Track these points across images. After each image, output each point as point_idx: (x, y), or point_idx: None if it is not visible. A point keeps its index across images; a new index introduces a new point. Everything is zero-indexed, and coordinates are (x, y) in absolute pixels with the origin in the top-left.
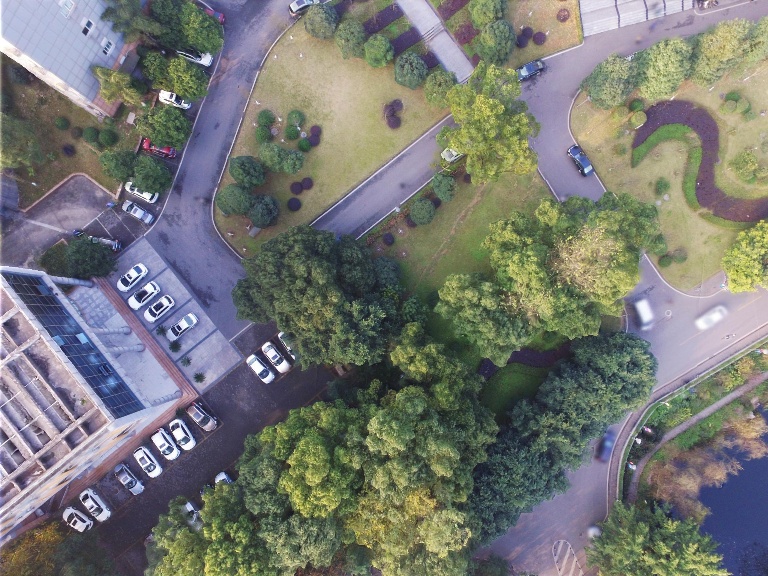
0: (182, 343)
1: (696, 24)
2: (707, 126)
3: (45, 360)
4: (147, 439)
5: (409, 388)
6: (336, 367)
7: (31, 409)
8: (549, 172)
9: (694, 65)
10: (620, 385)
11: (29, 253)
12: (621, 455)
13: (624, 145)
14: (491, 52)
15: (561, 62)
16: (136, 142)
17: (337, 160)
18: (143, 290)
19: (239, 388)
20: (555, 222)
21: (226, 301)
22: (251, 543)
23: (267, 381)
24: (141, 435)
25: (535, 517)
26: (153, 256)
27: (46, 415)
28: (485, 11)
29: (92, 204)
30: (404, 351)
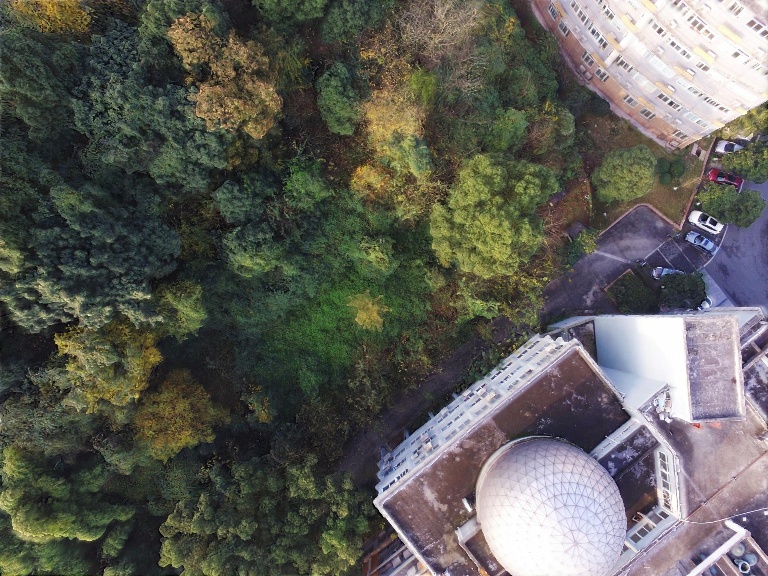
0: None
1: None
2: None
3: None
4: None
5: None
6: None
7: None
8: None
9: None
10: None
11: (594, 282)
12: None
13: None
14: None
15: None
16: (699, 173)
17: None
18: None
19: None
20: None
21: None
22: None
23: None
24: None
25: None
26: (712, 287)
27: None
28: None
29: (653, 234)
30: None
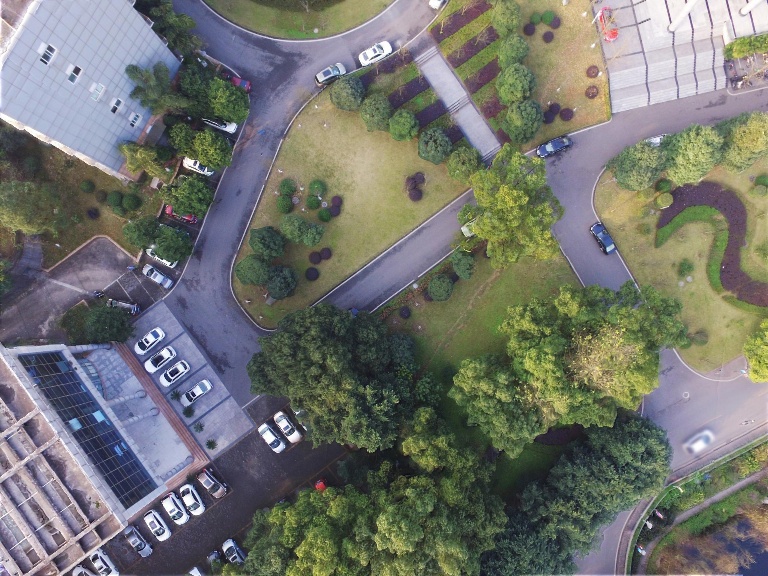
0: (196, 408)
1: (728, 104)
2: (735, 209)
3: (63, 461)
4: (157, 503)
5: (420, 479)
6: None
7: (47, 509)
8: (570, 249)
9: (725, 153)
10: (633, 476)
11: (50, 312)
12: (631, 537)
13: (648, 225)
14: (517, 131)
15: (587, 138)
16: (159, 206)
17: (357, 231)
18: (160, 355)
19: (250, 455)
20: (575, 315)
21: (241, 368)
22: None
23: (278, 451)
24: None
25: None
26: (171, 320)
27: (62, 517)
28: (512, 90)
29: (113, 266)
30: (416, 445)
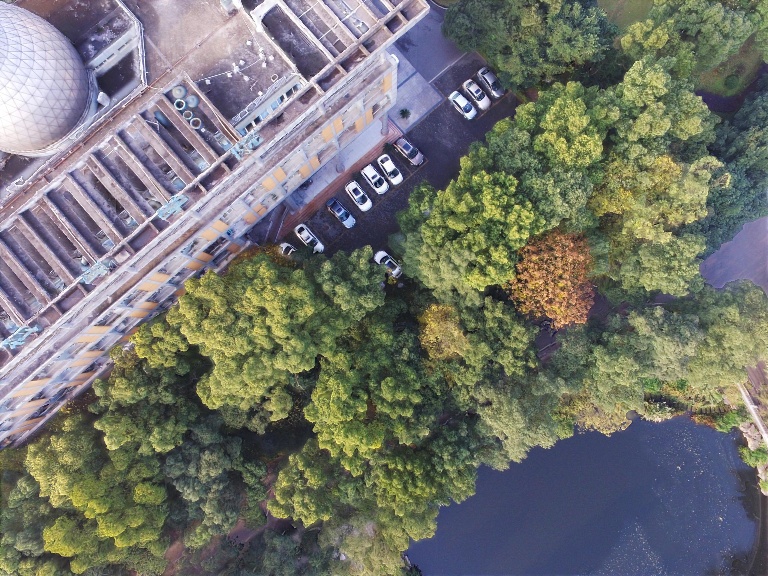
0: None
1: None
2: None
3: None
4: (357, 174)
5: None
6: None
7: (350, 2)
8: None
9: None
10: None
11: None
12: None
13: None
14: None
15: None
16: None
17: None
18: None
19: (441, 126)
20: None
21: (424, 45)
22: (517, 193)
23: (470, 116)
24: (350, 172)
25: (723, 264)
26: None
27: (366, 5)
28: None
29: None
30: (643, 23)
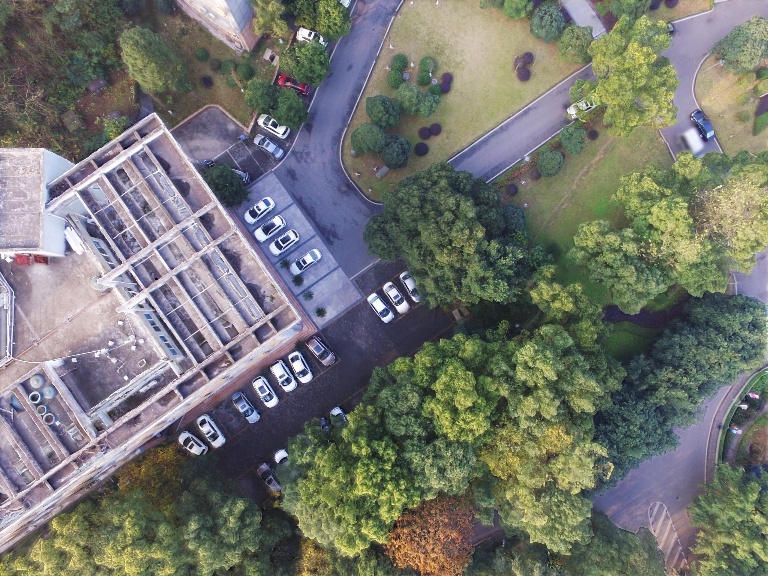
0: (304, 278)
1: None
2: None
3: (237, 256)
4: (266, 369)
5: (549, 326)
6: (453, 312)
7: (221, 302)
8: (670, 135)
9: None
10: (741, 344)
11: None
12: (722, 421)
13: (748, 112)
14: (629, 9)
15: (690, 27)
16: (271, 78)
17: (465, 108)
18: (271, 222)
19: (357, 326)
20: (697, 174)
21: (349, 240)
22: (396, 463)
23: (386, 320)
24: (260, 365)
25: (633, 477)
26: (280, 191)
27: (236, 309)
28: None
29: (224, 136)
30: (550, 287)
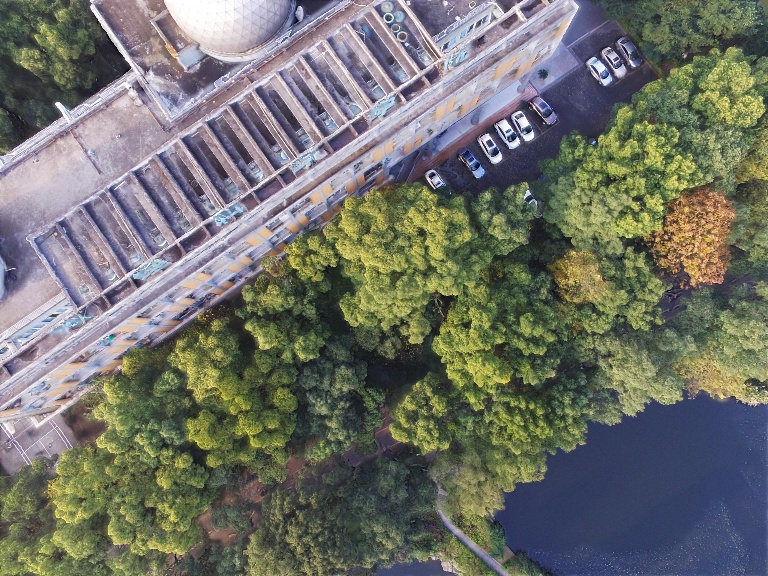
0: None
1: None
2: None
3: None
4: (490, 127)
5: None
6: None
7: None
8: None
9: None
10: None
11: None
12: None
13: None
14: None
15: None
16: None
17: None
18: None
19: (575, 90)
20: None
21: None
22: None
23: (605, 83)
24: (483, 125)
25: None
26: None
27: None
28: None
29: None
30: None
